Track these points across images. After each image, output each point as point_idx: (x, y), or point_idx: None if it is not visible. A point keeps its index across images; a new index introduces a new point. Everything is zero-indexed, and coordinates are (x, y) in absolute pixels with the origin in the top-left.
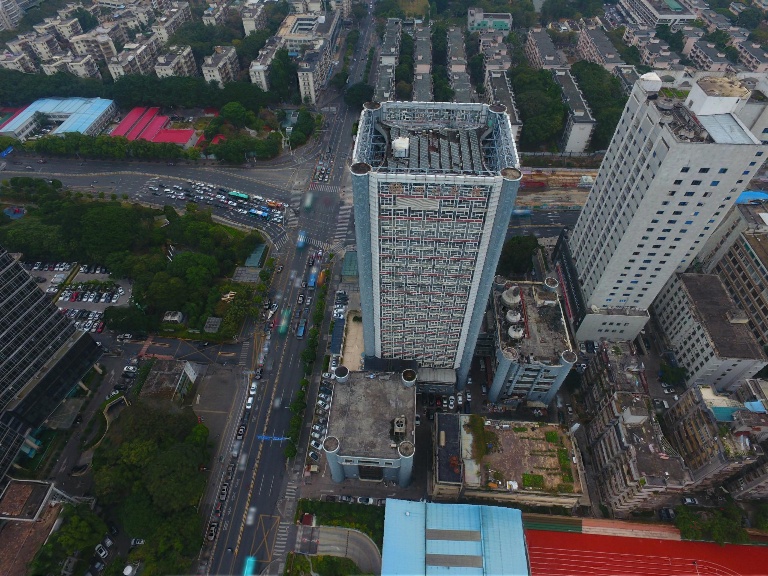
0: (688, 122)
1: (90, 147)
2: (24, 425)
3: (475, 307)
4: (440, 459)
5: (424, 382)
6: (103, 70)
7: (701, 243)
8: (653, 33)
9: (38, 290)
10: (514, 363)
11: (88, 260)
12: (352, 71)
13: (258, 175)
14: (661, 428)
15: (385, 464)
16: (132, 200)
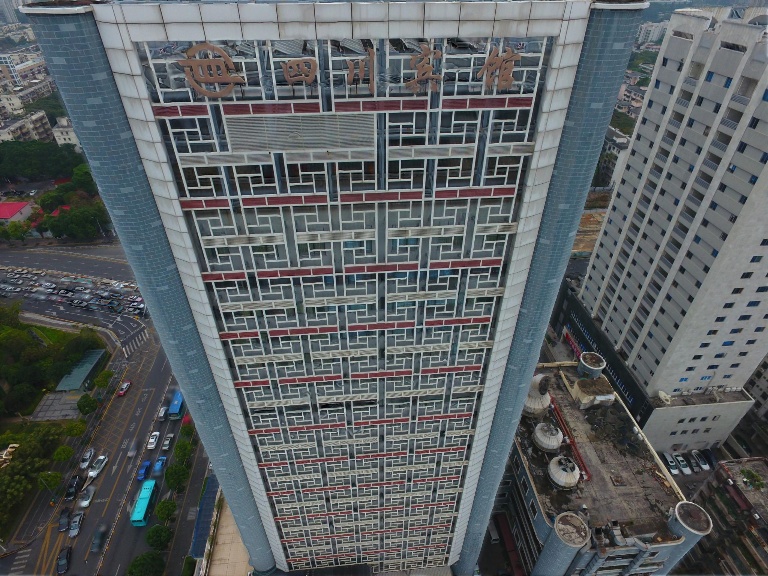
0: None
1: None
2: None
3: (491, 440)
4: None
5: None
6: None
7: None
8: None
9: None
10: (584, 551)
11: None
12: None
13: (116, 252)
14: None
15: None
16: None
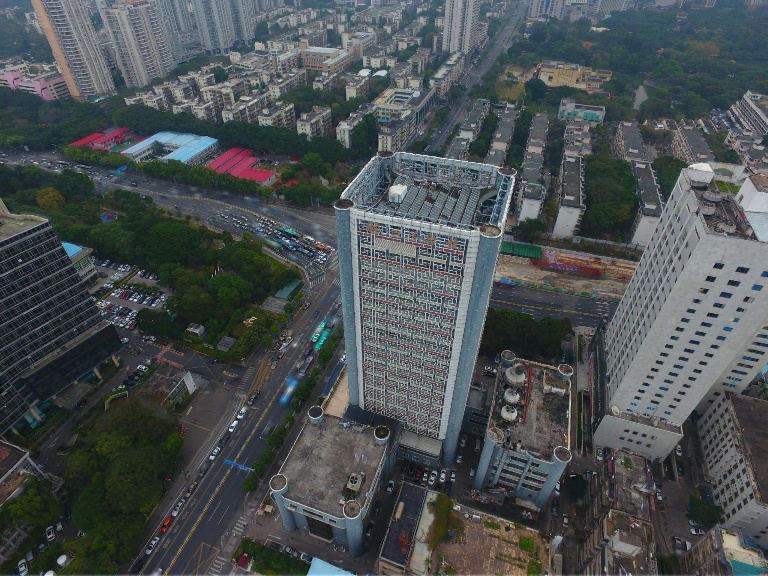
0: (736, 217)
1: (185, 174)
2: (33, 395)
3: (458, 372)
4: (390, 532)
5: (406, 447)
6: (219, 115)
7: (761, 362)
8: (759, 140)
9: (76, 276)
10: (498, 446)
11: (146, 266)
12: (434, 141)
13: (317, 219)
14: (672, 573)
15: (329, 521)
16: (203, 223)
